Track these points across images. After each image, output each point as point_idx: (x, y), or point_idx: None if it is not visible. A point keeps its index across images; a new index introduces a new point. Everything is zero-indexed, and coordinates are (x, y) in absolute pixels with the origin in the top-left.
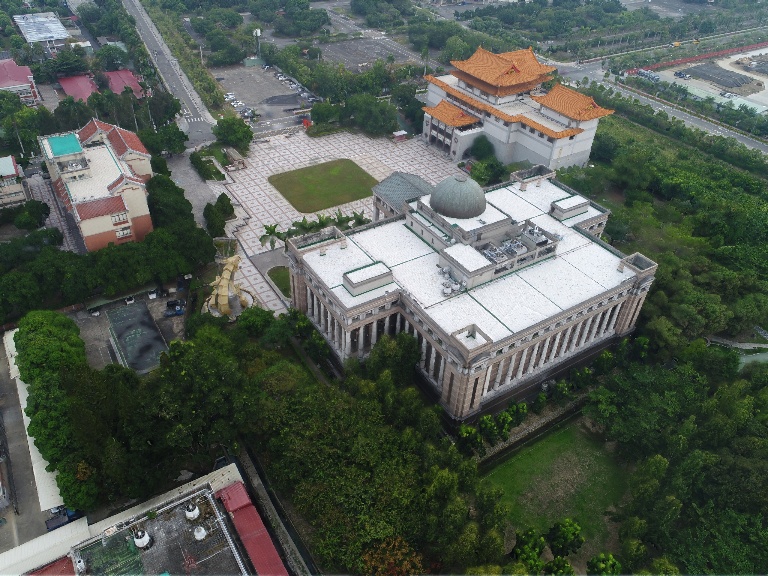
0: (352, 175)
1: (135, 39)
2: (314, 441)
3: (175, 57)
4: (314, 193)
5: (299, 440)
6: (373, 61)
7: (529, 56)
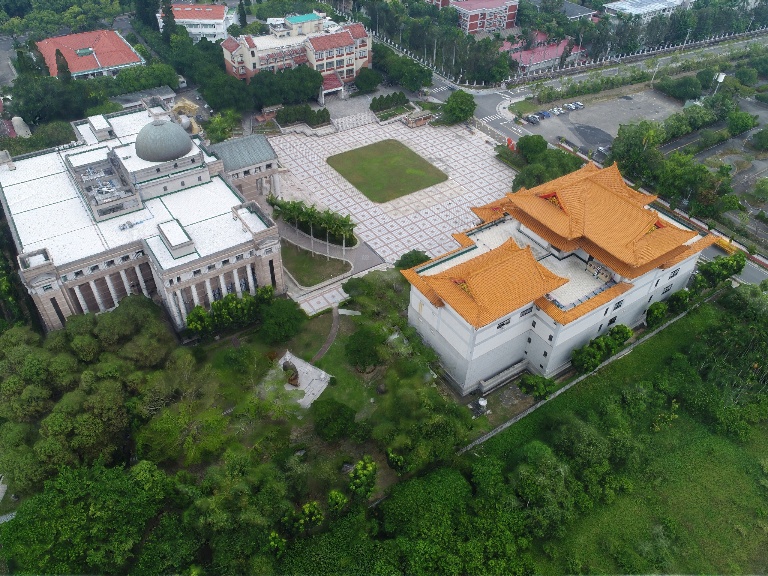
0: (407, 181)
1: (585, 19)
2: (7, 147)
3: (644, 63)
4: (364, 162)
5: (8, 140)
6: (760, 177)
7: (639, 221)
